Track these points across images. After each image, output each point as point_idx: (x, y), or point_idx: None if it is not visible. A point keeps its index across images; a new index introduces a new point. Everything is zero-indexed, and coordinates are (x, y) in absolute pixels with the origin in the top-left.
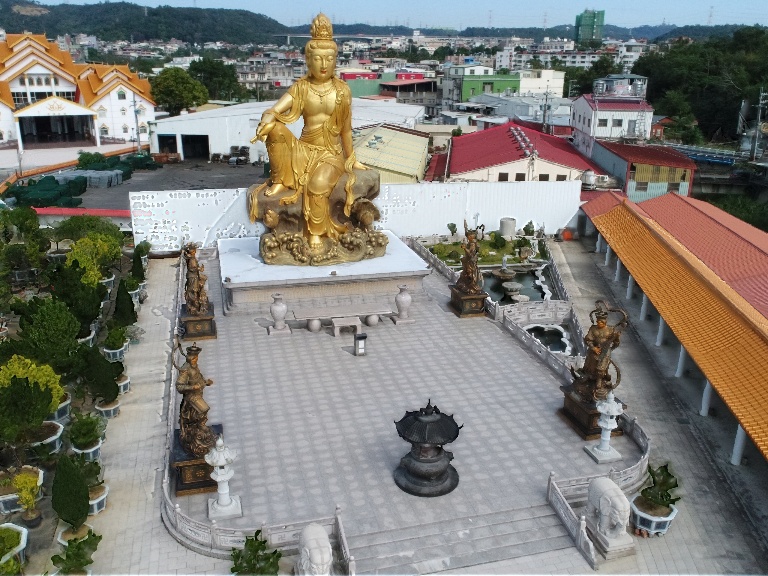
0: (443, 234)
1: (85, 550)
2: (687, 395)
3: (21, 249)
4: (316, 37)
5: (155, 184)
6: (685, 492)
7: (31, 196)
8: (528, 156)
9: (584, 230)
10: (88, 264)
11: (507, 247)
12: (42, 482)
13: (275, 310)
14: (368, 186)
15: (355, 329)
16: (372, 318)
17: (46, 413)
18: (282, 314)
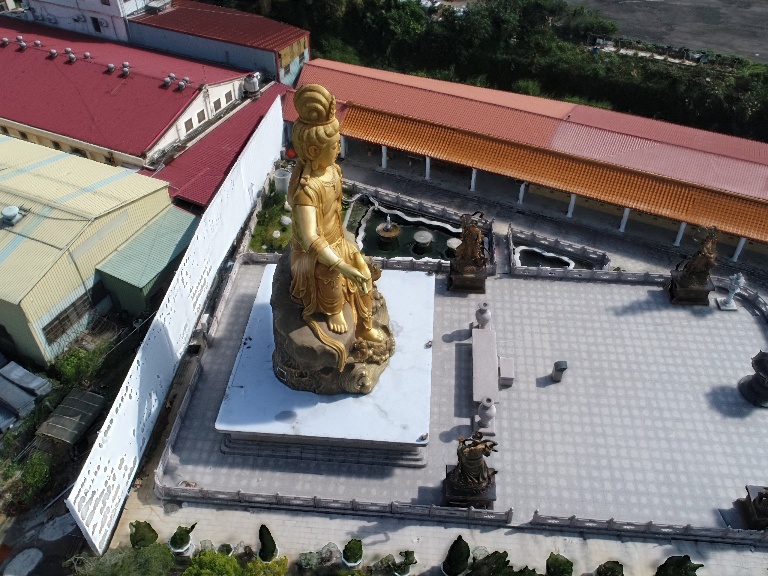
0: (239, 227)
1: None
2: (650, 240)
3: None
4: (329, 121)
5: None
6: (765, 291)
7: None
8: (197, 89)
9: (286, 138)
10: None
11: None
12: None
13: None
14: None
15: None
16: None
17: None
18: None
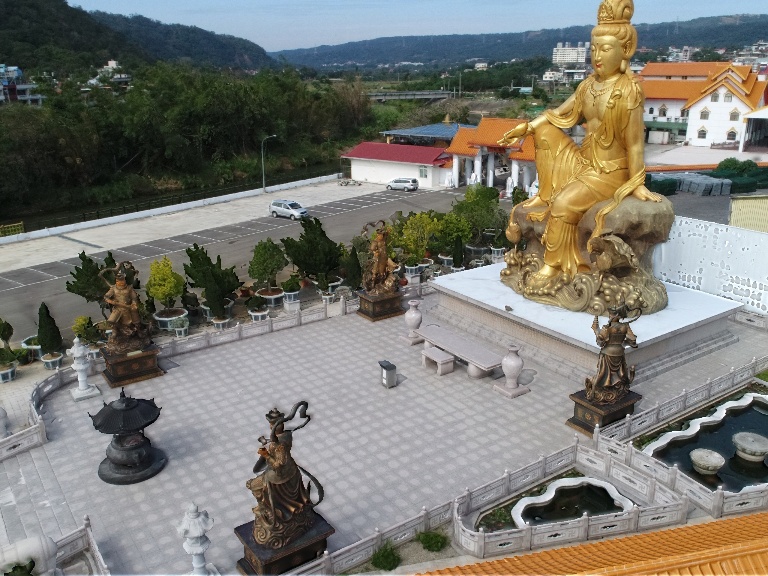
0: None
1: (6, 355)
2: None
3: (414, 215)
4: None
5: None
6: None
7: None
8: None
9: None
10: None
11: None
12: (110, 332)
13: (405, 315)
14: (627, 221)
15: None
16: (469, 366)
17: (103, 287)
18: (409, 322)
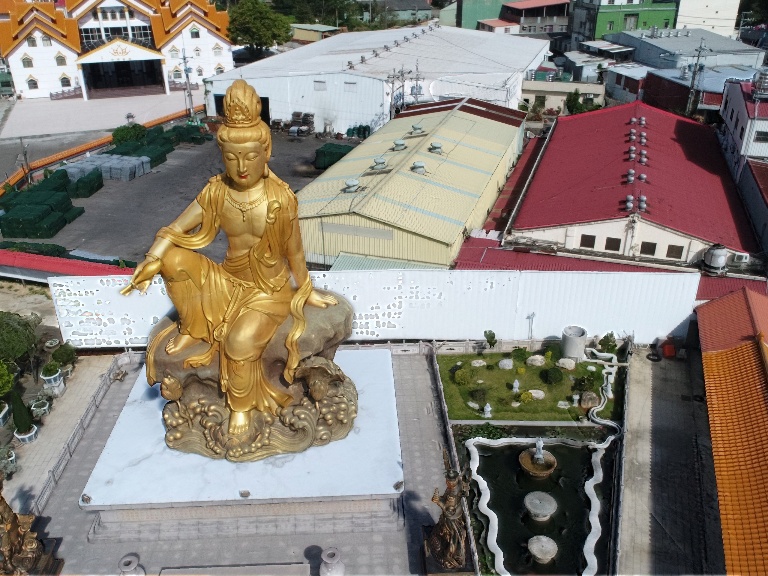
0: (481, 336)
1: None
2: None
3: None
4: (227, 122)
5: (186, 174)
6: None
7: (14, 214)
8: (627, 214)
9: (698, 339)
10: None
11: (563, 385)
12: None
13: None
14: (324, 338)
15: None
16: None
17: None
18: None
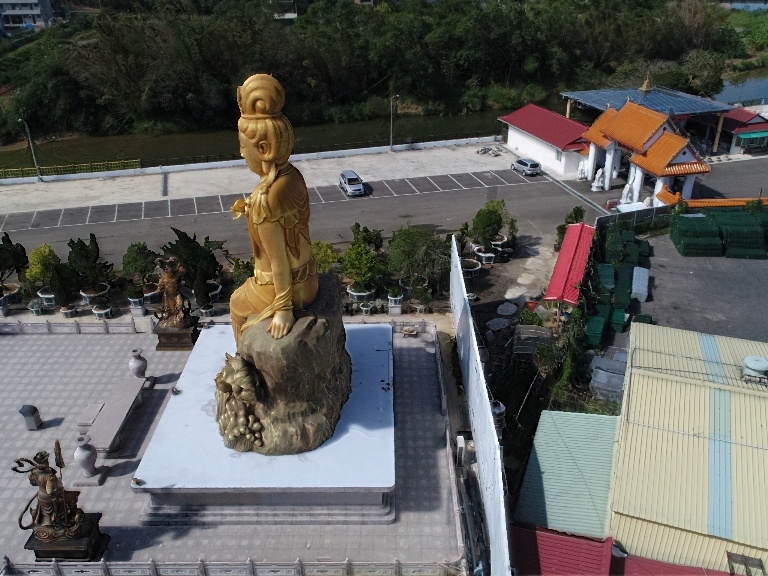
0: None
1: None
2: None
3: (362, 231)
4: None
5: None
6: None
7: (687, 220)
8: None
9: None
10: None
11: None
12: None
13: None
14: None
15: None
16: None
17: None
18: None
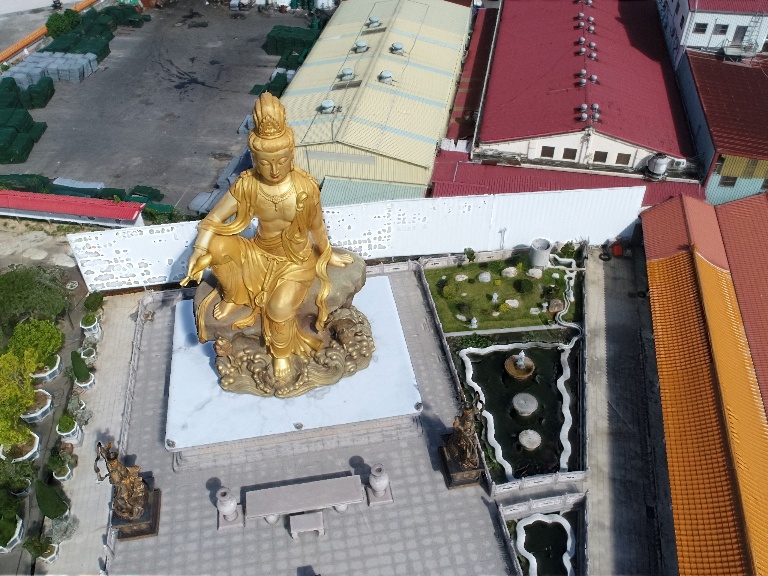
0: (460, 249)
1: None
2: None
3: None
4: (259, 134)
5: (136, 70)
6: None
7: None
8: (583, 127)
9: (641, 237)
10: (6, 422)
11: (534, 293)
12: None
13: (221, 511)
14: (347, 293)
15: (317, 531)
16: (339, 507)
17: None
18: (230, 513)
